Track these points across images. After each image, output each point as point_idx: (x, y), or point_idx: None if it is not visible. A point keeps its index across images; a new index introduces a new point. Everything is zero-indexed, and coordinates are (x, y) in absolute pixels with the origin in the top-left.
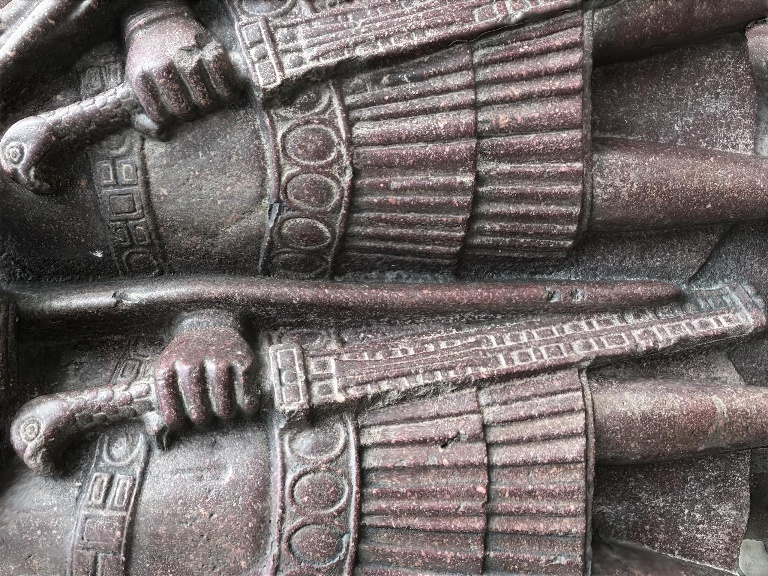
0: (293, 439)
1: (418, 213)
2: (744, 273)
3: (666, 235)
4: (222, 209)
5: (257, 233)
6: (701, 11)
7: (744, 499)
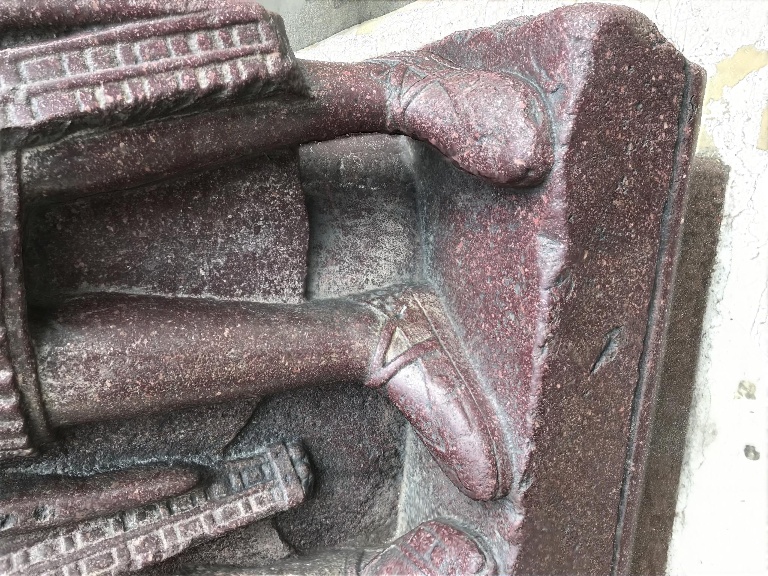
0: None
1: None
2: (294, 428)
3: None
4: None
5: None
6: (204, 147)
7: None
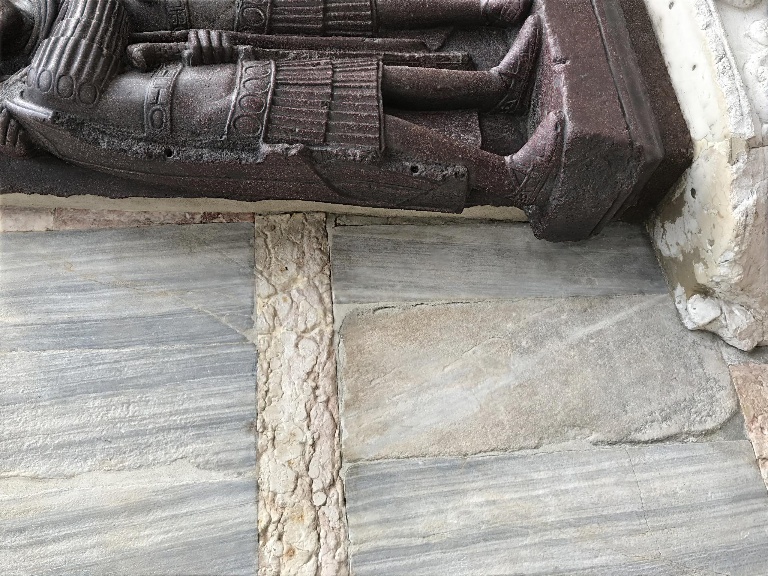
0: (246, 62)
1: (301, 7)
2: None
3: (420, 33)
4: (218, 6)
5: (232, 17)
6: None
7: (478, 133)
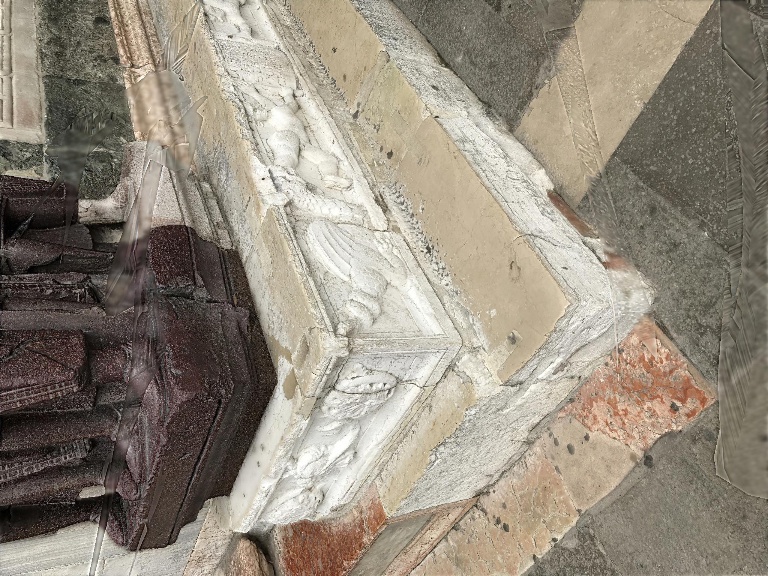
0: None
1: None
2: None
3: None
4: None
5: None
6: None
7: None
